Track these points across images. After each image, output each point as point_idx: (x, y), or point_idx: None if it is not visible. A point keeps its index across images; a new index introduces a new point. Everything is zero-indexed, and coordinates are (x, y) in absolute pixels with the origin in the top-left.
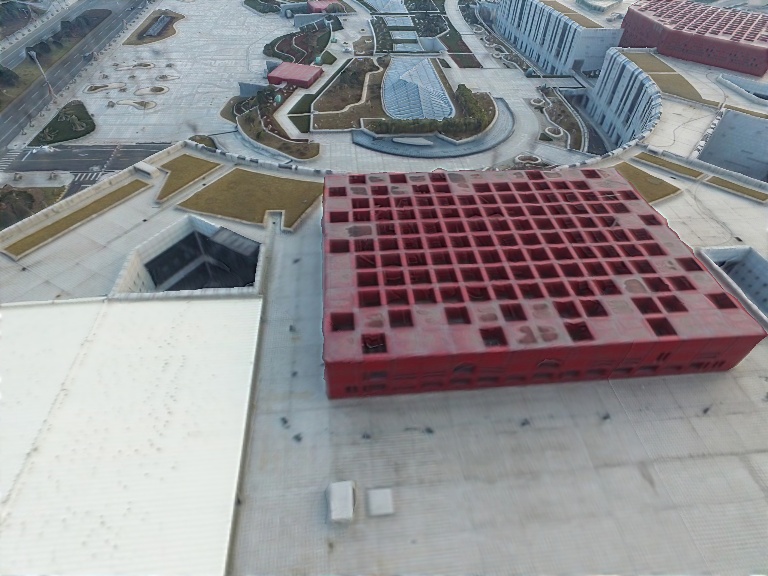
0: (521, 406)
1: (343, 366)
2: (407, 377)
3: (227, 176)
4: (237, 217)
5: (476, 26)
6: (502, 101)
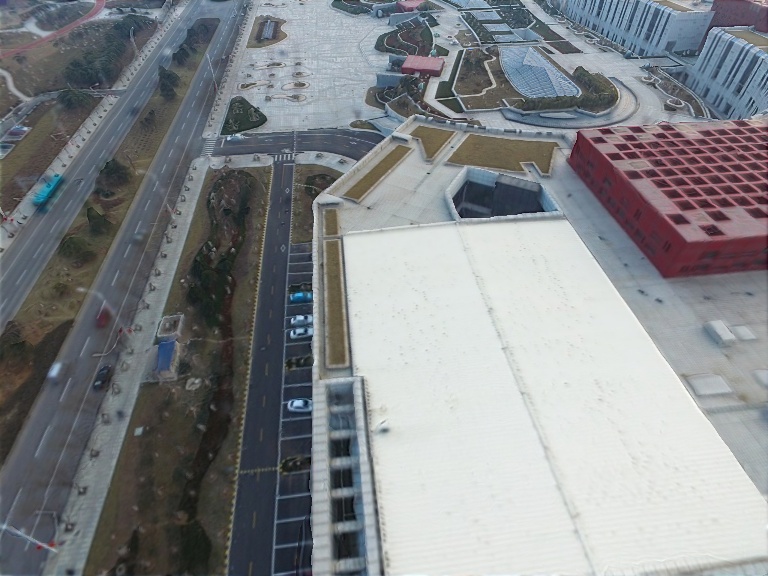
0: None
1: (698, 245)
2: (729, 256)
3: (468, 140)
4: (501, 168)
5: (556, 17)
6: (616, 80)
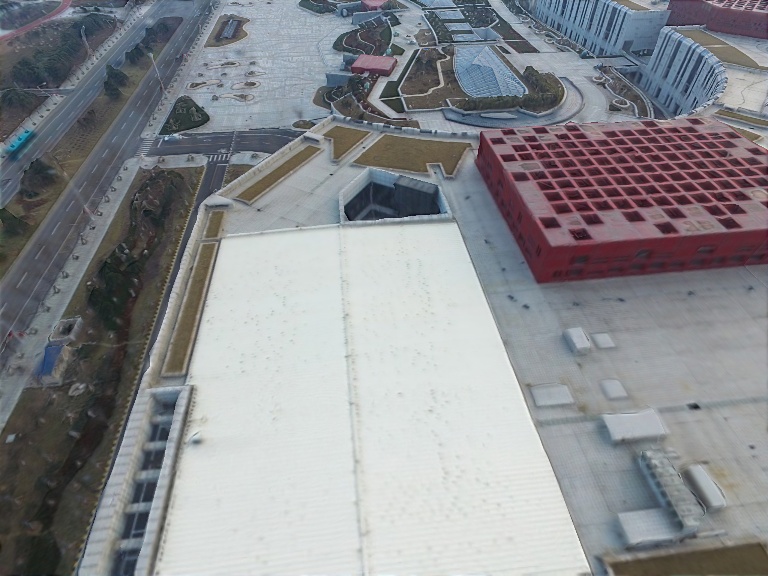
0: (684, 283)
1: (563, 249)
2: (601, 261)
3: (381, 140)
4: (406, 169)
5: (521, 16)
6: (566, 80)
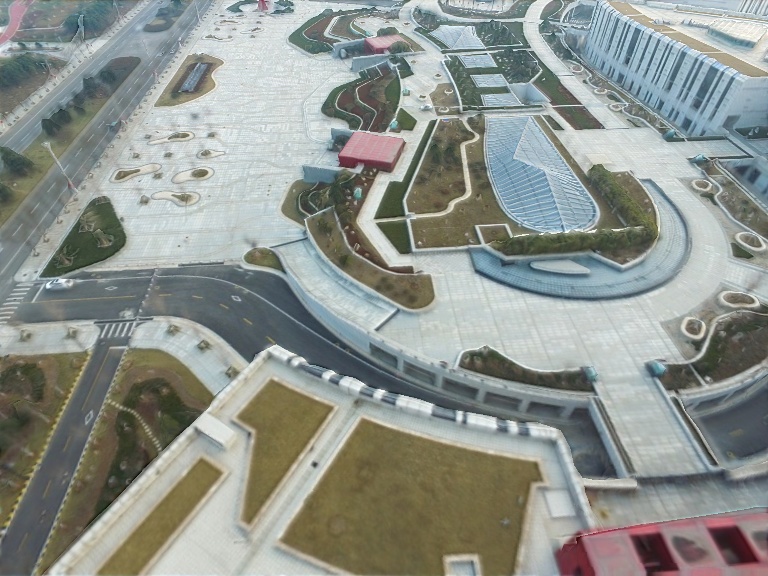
0: None
1: None
2: None
3: (351, 444)
4: None
5: (571, 62)
6: (653, 185)
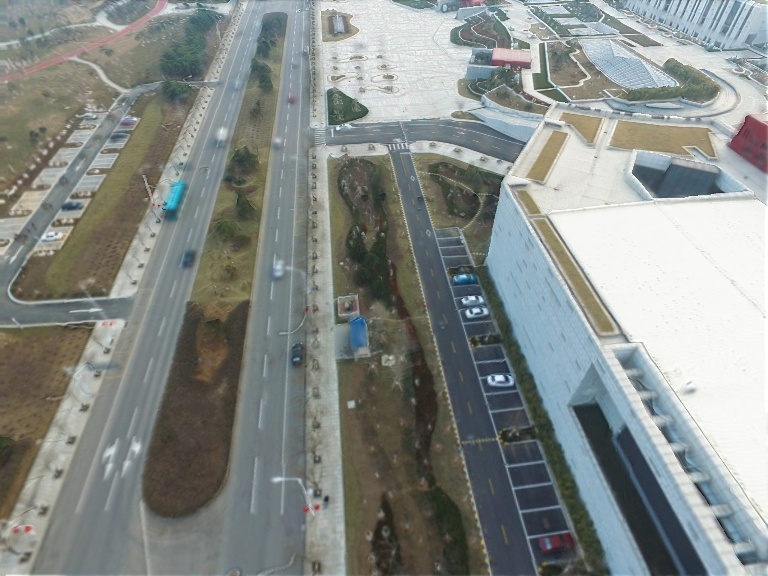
0: None
1: None
2: None
3: (620, 126)
4: (667, 151)
5: (622, 11)
6: (707, 71)
